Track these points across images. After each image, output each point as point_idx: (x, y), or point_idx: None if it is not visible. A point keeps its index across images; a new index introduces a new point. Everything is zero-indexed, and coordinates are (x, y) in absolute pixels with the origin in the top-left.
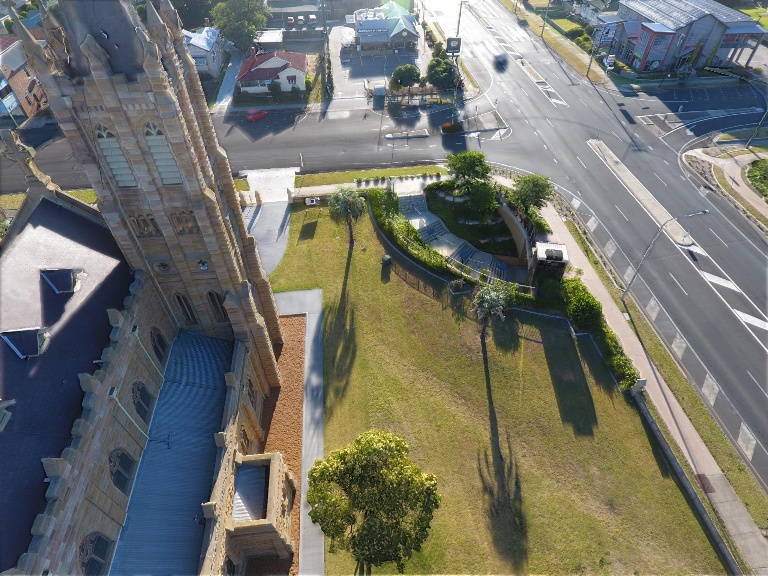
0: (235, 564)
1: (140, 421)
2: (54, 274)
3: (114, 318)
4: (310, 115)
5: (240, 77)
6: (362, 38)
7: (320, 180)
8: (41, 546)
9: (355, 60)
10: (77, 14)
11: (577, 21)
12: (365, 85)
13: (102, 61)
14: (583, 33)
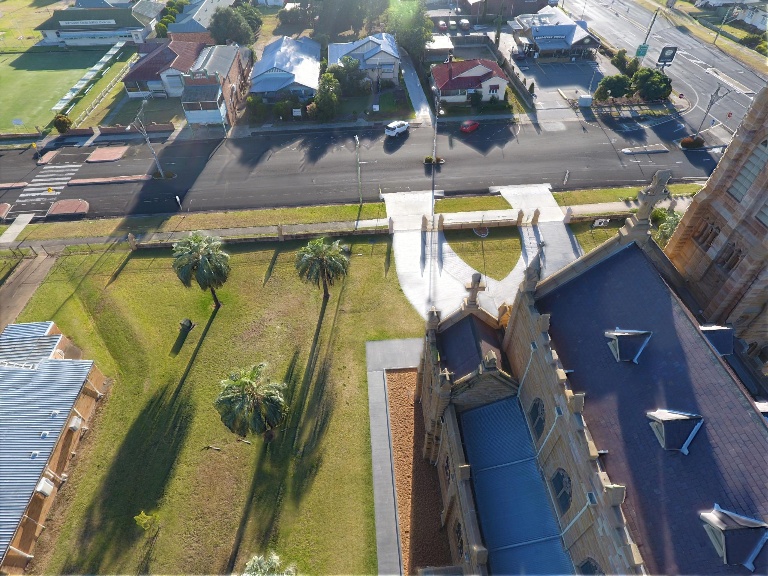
0: None
1: None
2: (716, 335)
3: None
4: (524, 127)
5: (442, 86)
6: (540, 45)
7: (582, 198)
8: None
9: (534, 68)
10: None
11: (741, 27)
12: (562, 95)
13: None
14: (759, 40)
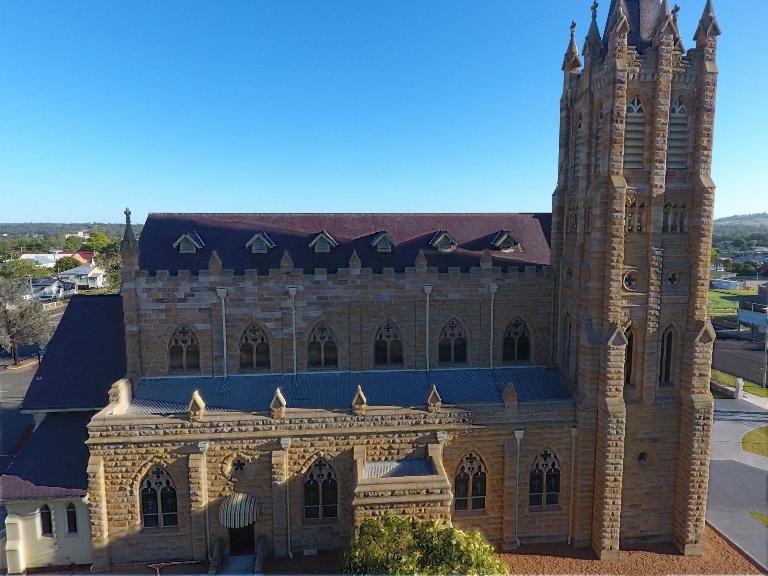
0: (338, 514)
1: (435, 350)
2: None
3: (483, 257)
4: None
5: None
6: None
7: None
8: (308, 276)
9: None
10: (608, 26)
11: None
12: None
13: (594, 50)
14: None
